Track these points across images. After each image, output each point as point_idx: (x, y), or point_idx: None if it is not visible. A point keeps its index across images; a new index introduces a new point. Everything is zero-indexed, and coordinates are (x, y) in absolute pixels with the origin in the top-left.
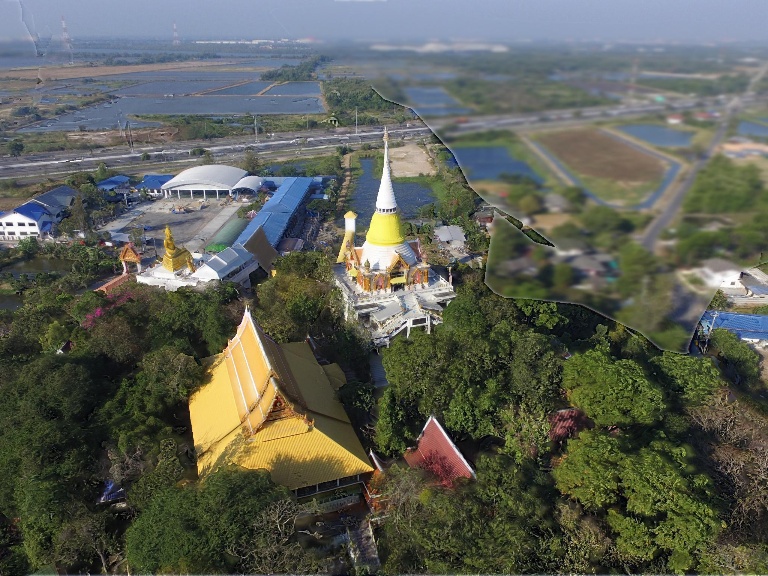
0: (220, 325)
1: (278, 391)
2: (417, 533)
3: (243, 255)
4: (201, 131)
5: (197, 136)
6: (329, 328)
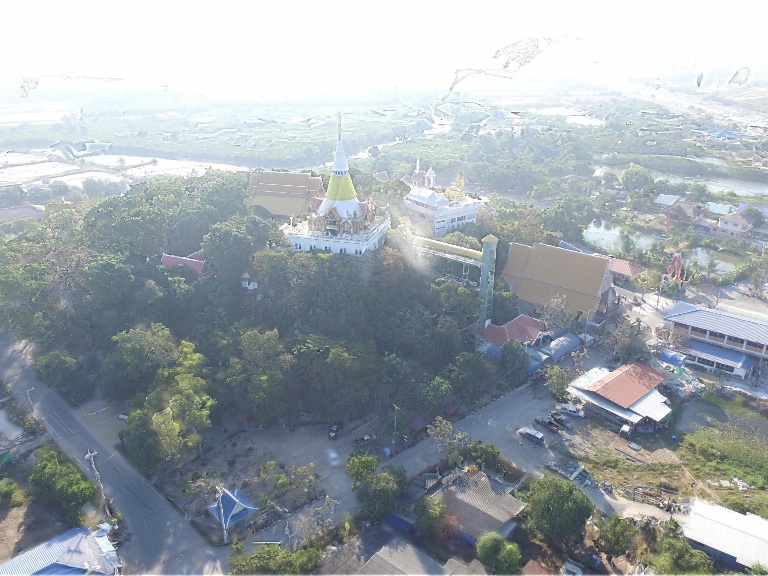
0: None
1: (251, 173)
2: None
3: (432, 200)
4: None
5: None
6: None
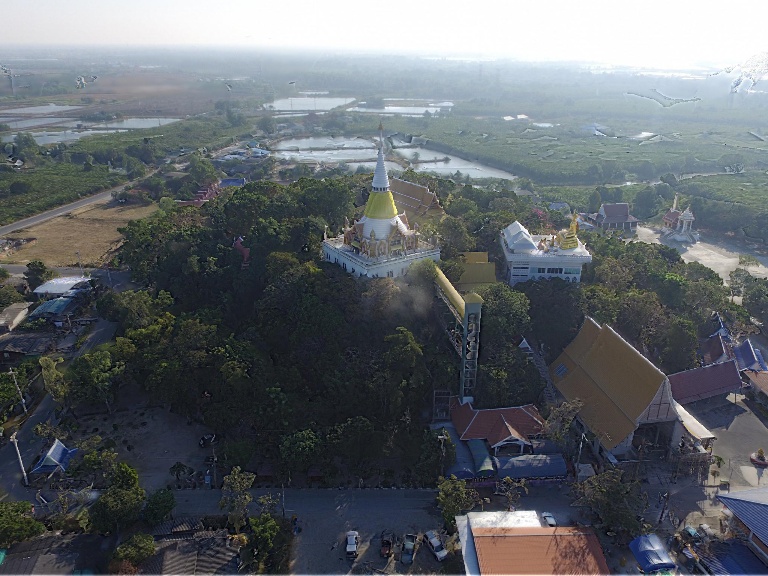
0: None
1: None
2: None
3: None
4: None
5: None
6: None
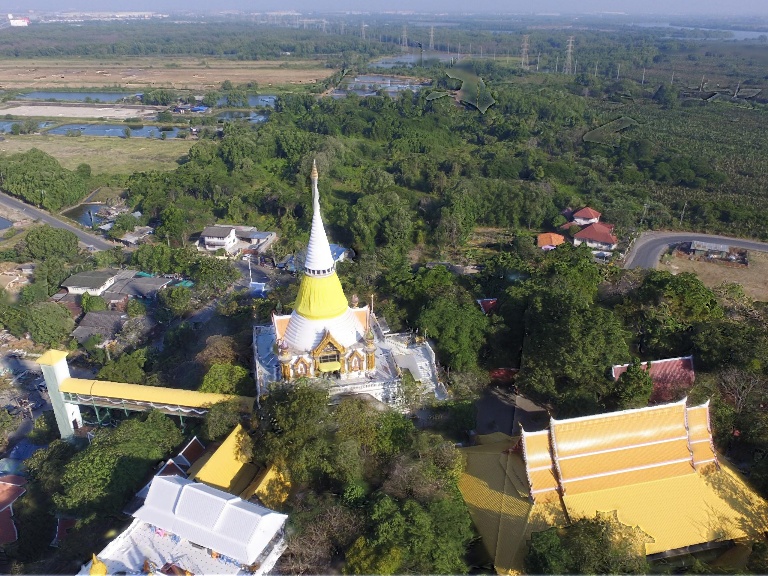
0: None
1: None
2: None
3: None
4: None
5: None
6: None
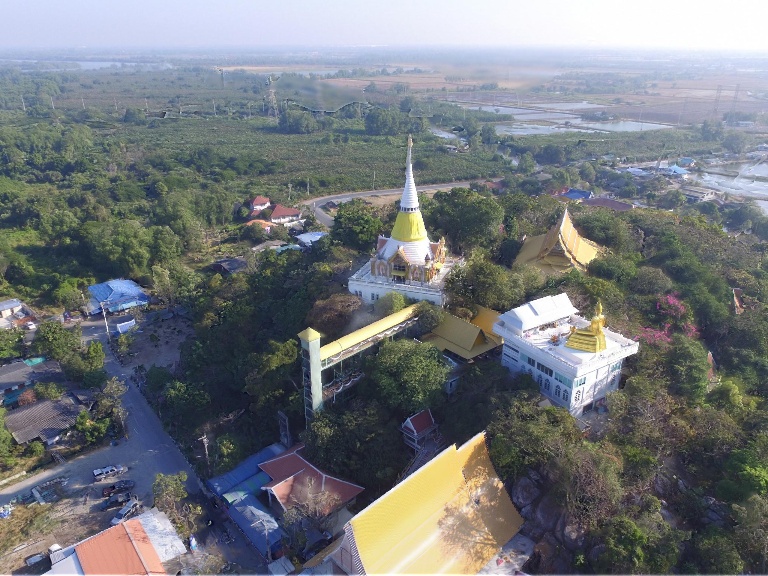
0: None
1: None
2: None
3: None
4: None
5: None
6: None
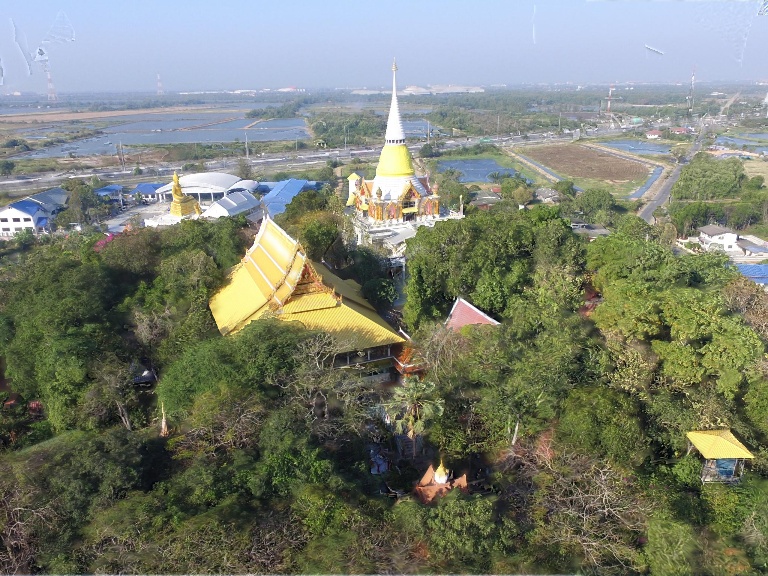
0: (235, 245)
1: (307, 259)
2: (462, 355)
3: (251, 201)
4: (191, 152)
5: (188, 157)
6: (342, 259)
